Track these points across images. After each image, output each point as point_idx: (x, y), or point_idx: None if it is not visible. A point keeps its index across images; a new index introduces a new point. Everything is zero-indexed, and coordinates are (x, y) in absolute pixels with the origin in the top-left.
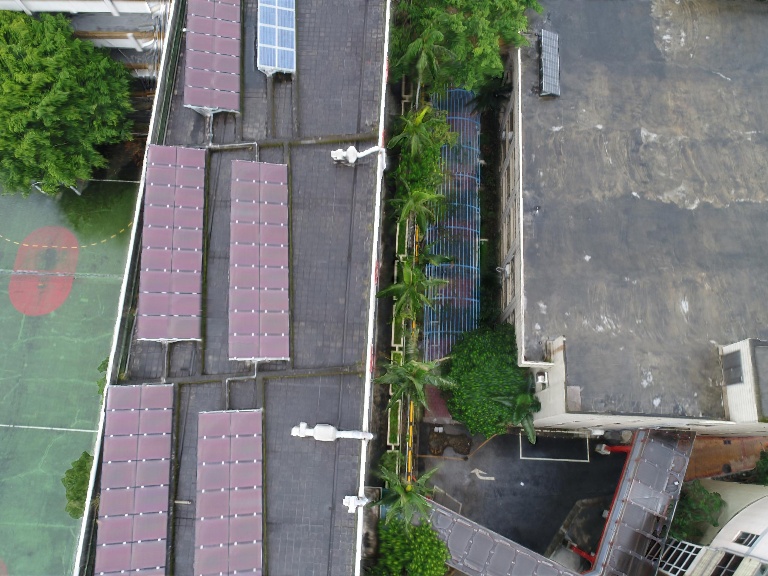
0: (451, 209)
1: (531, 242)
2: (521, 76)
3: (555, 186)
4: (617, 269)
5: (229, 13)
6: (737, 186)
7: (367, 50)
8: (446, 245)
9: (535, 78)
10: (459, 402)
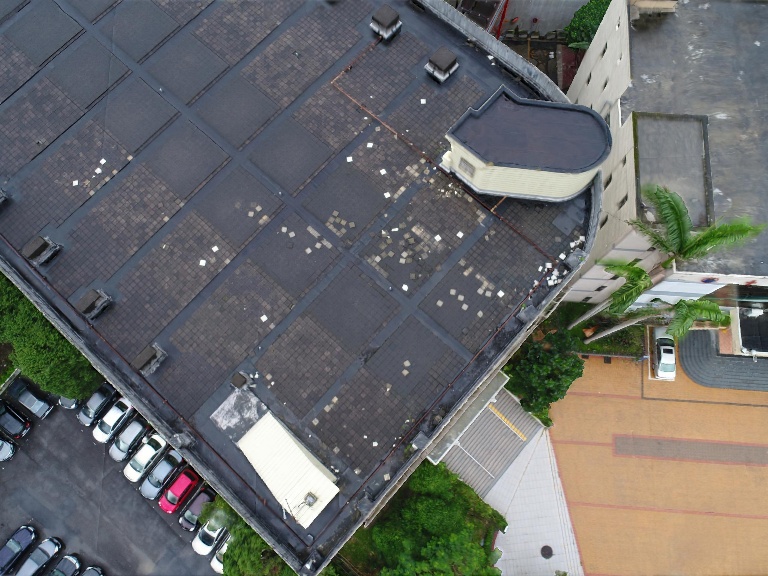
0: None
1: (766, 1)
2: None
3: None
4: (750, 65)
5: None
6: None
7: None
8: None
9: None
10: (598, 0)
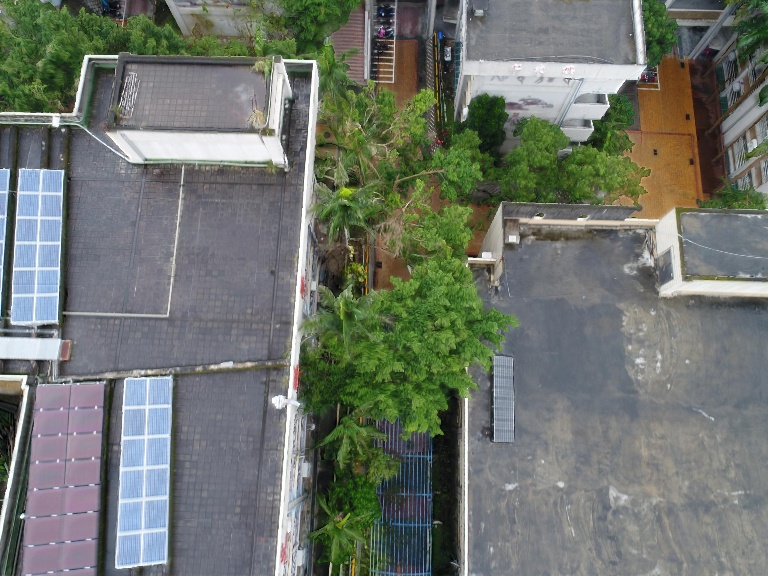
0: (398, 501)
1: None
2: (469, 413)
3: (507, 567)
4: None
5: (85, 473)
6: (721, 568)
7: (260, 519)
8: (392, 548)
9: (486, 415)
10: None
